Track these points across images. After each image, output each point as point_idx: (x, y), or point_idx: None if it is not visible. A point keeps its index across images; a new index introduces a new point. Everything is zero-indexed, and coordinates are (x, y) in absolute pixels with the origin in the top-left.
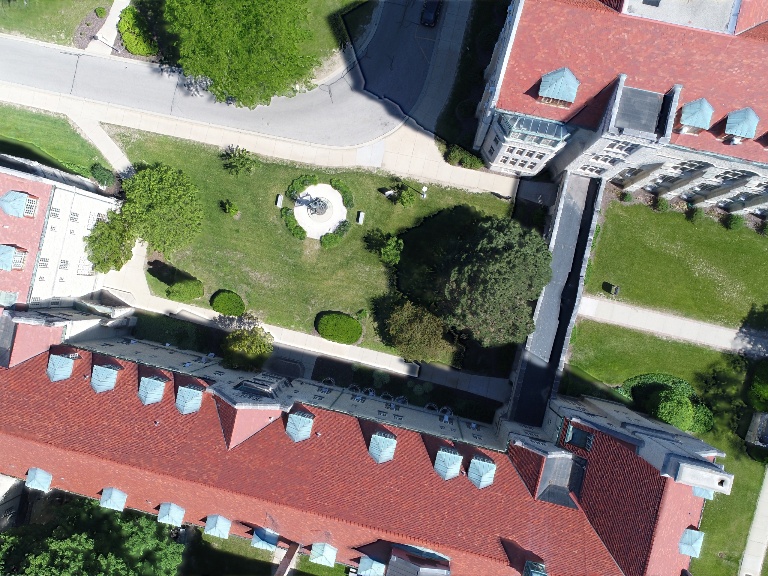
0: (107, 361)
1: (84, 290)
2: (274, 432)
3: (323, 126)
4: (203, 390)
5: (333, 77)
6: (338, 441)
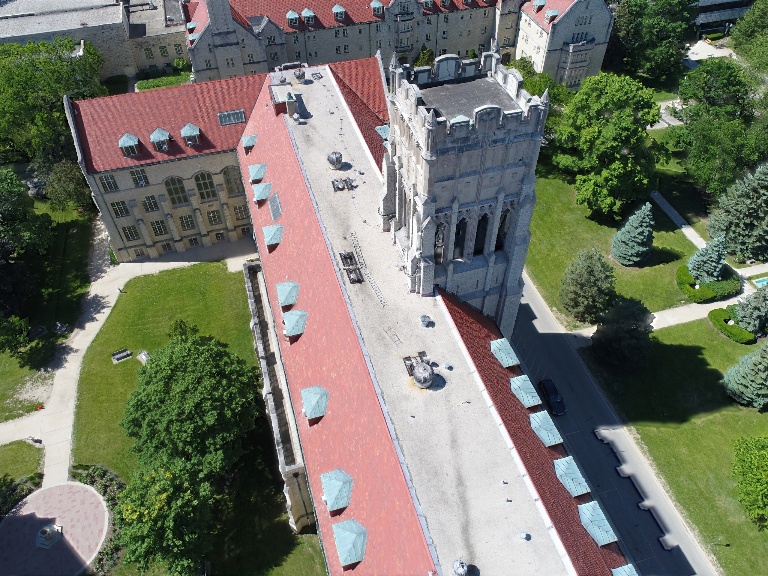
0: (472, 5)
1: (517, 56)
2: (385, 0)
3: None
4: (425, 5)
5: None
6: (358, 7)
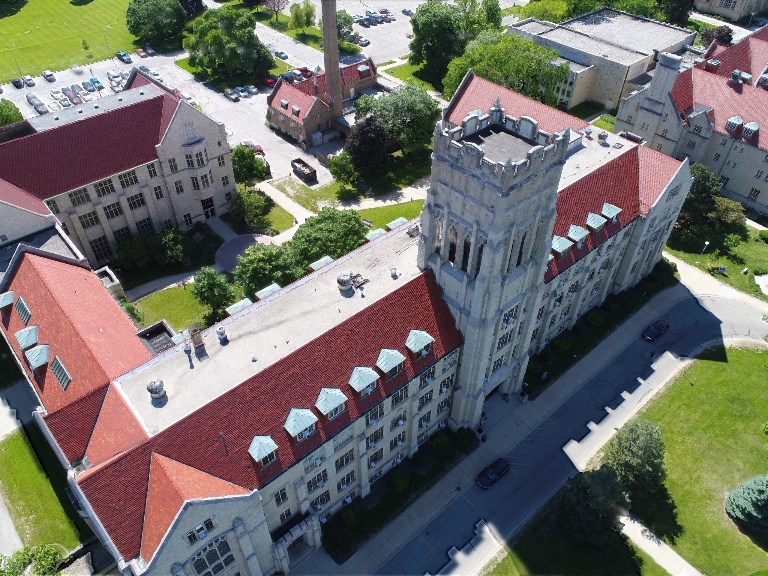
0: None
1: None
2: None
3: (760, 320)
4: None
5: (744, 338)
6: None
